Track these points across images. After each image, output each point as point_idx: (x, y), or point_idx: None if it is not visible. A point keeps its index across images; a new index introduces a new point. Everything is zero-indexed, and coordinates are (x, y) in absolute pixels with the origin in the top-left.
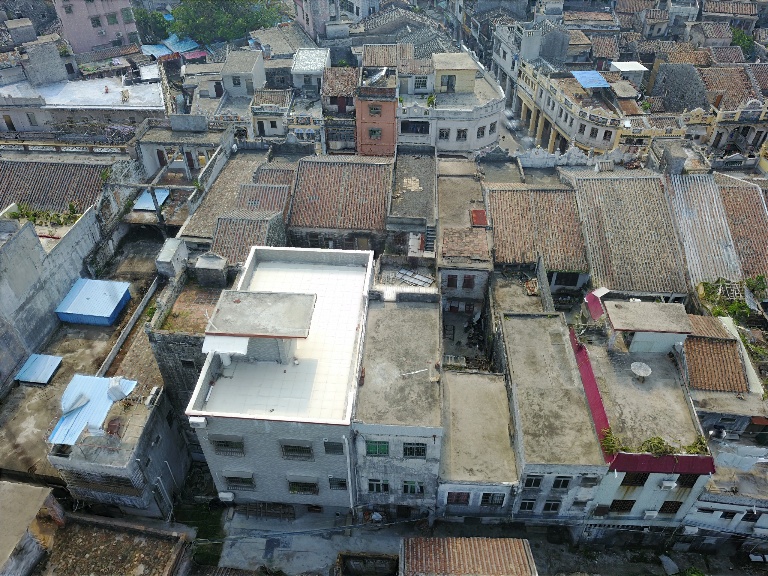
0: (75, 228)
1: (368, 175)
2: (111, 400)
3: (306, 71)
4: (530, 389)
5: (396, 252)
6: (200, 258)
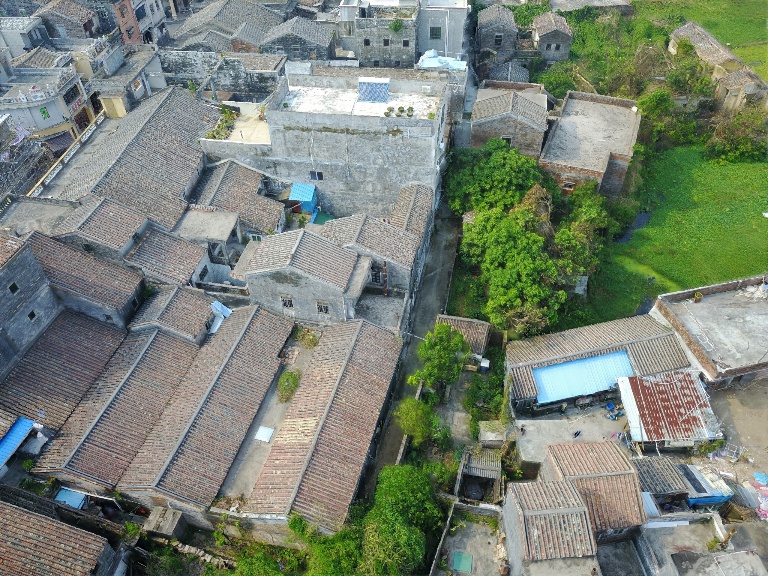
0: (253, 105)
1: (238, 5)
2: (438, 57)
3: (33, 24)
4: None
5: (310, 14)
6: (360, 6)
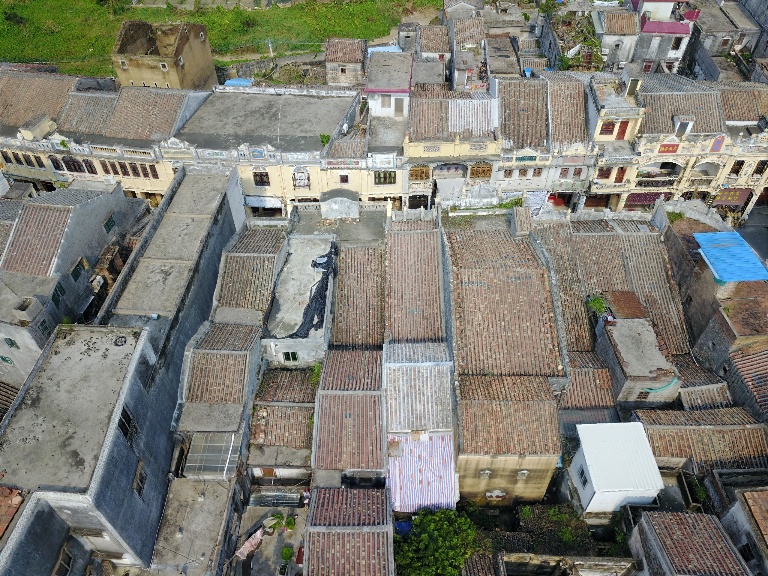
0: None
1: None
2: None
3: None
4: (713, 7)
5: None
6: None
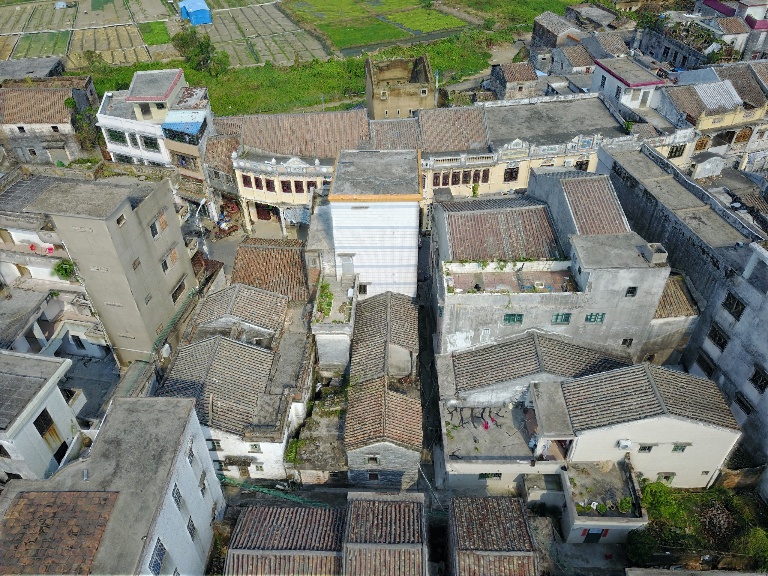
0: None
1: None
2: None
3: None
4: None
5: None
6: None
